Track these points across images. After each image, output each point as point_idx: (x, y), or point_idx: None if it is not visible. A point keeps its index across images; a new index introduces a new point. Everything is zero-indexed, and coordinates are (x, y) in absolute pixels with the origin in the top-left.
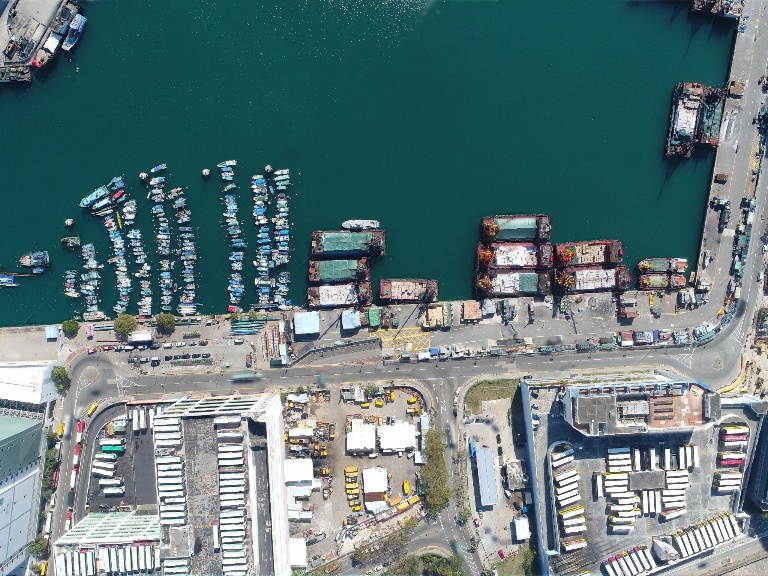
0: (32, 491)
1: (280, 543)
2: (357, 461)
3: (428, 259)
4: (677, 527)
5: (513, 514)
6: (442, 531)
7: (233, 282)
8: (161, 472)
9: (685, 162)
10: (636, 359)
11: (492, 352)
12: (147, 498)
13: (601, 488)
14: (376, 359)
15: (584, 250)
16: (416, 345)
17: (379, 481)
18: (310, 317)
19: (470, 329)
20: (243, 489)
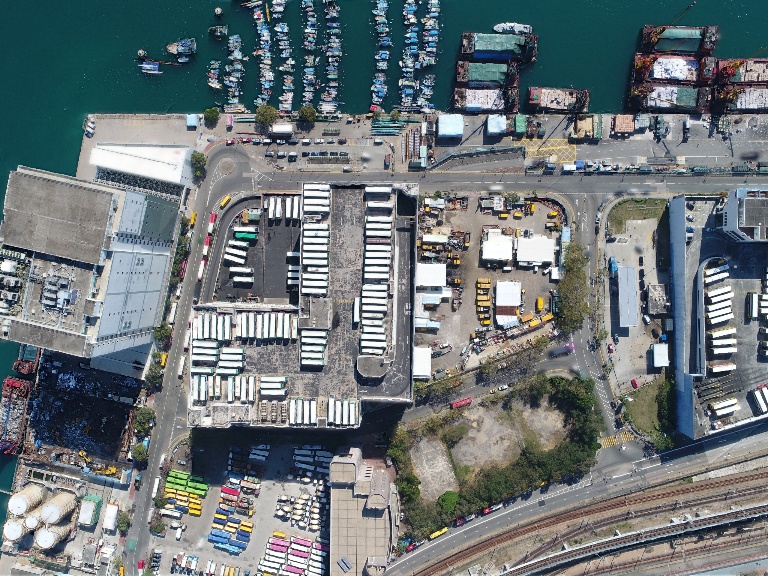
0: (163, 273)
1: None
2: (490, 274)
3: (580, 69)
4: None
5: (650, 342)
6: (573, 354)
7: (377, 82)
8: (307, 238)
9: None
10: None
11: (642, 168)
12: (275, 291)
13: (756, 308)
14: (518, 169)
15: (749, 67)
16: (561, 157)
17: (512, 294)
18: (455, 118)
19: (619, 144)
20: (389, 262)
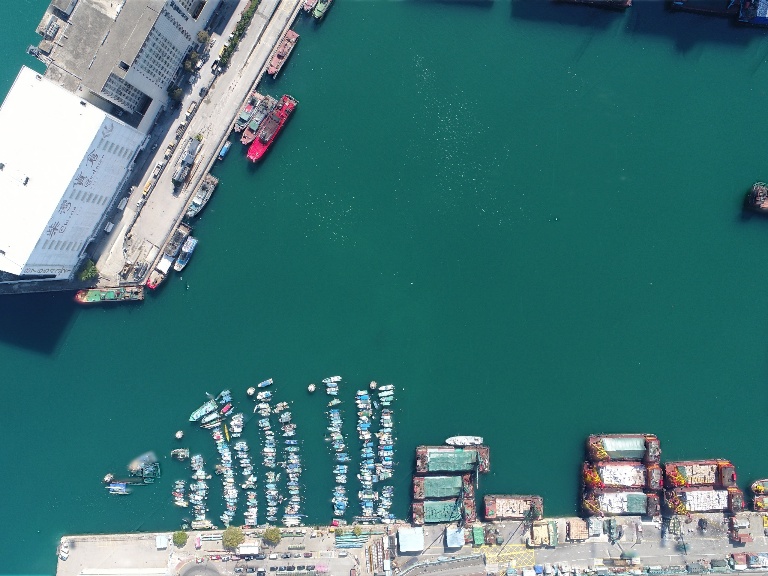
0: None
1: None
2: None
3: (532, 475)
4: None
5: None
6: None
7: (337, 495)
8: None
9: None
10: None
11: (599, 573)
12: None
13: None
14: (480, 575)
15: (694, 471)
16: (520, 562)
17: None
18: (415, 535)
19: (576, 547)
20: None
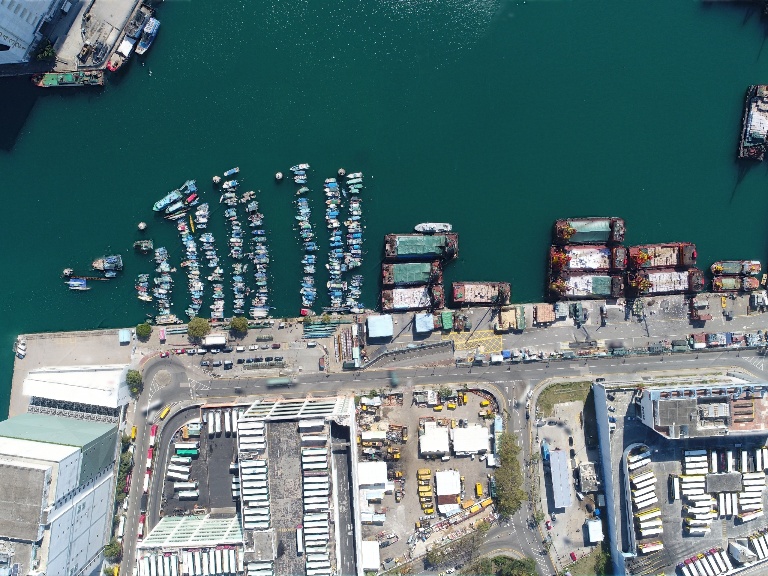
0: (107, 495)
1: (359, 546)
2: (429, 464)
3: (500, 262)
4: (753, 529)
5: (585, 516)
6: (514, 533)
7: (305, 285)
8: (245, 476)
9: (757, 164)
10: (708, 361)
11: (565, 355)
12: (221, 501)
13: (678, 490)
14: (449, 362)
15: (657, 253)
16: (488, 348)
17: (452, 484)
18: (384, 320)
19: (542, 332)
20: (327, 492)
